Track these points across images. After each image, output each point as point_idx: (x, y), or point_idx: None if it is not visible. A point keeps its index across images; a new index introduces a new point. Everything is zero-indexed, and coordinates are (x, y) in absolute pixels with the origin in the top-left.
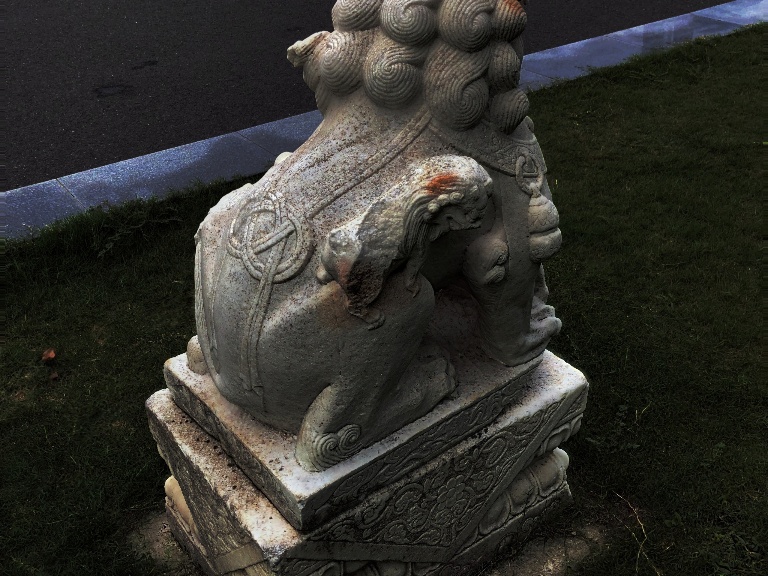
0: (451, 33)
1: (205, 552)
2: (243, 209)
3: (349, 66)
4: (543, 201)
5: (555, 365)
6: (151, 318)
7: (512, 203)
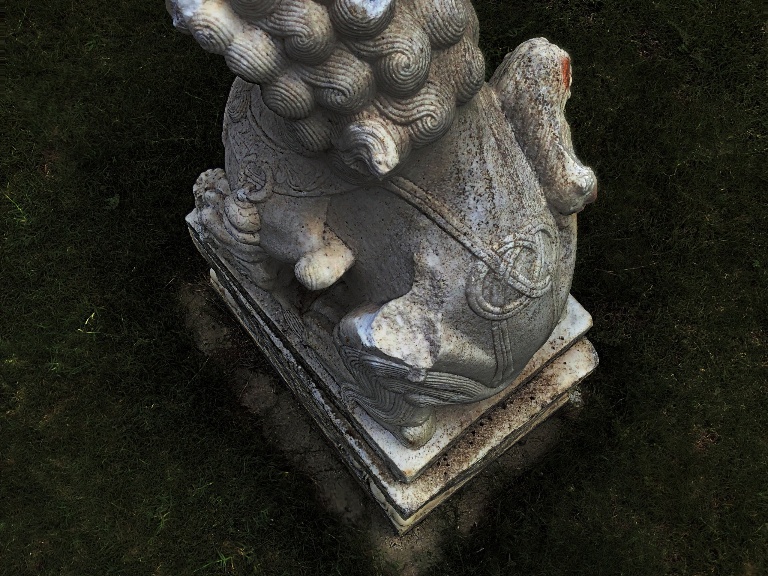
0: None
1: (473, 475)
2: (484, 291)
3: None
4: None
5: None
6: None
7: None
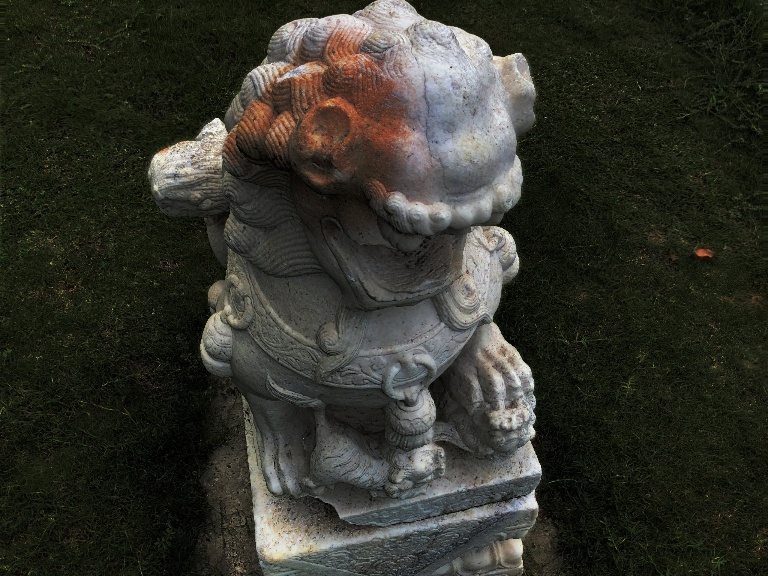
0: None
1: None
2: None
3: None
4: (216, 323)
5: (298, 537)
6: (766, 346)
7: None
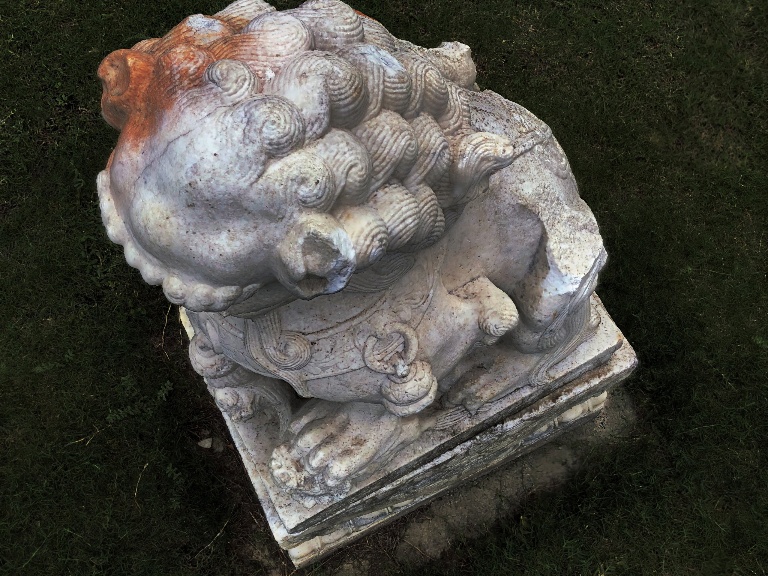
0: None
1: None
2: None
3: None
4: None
5: None
6: None
7: None
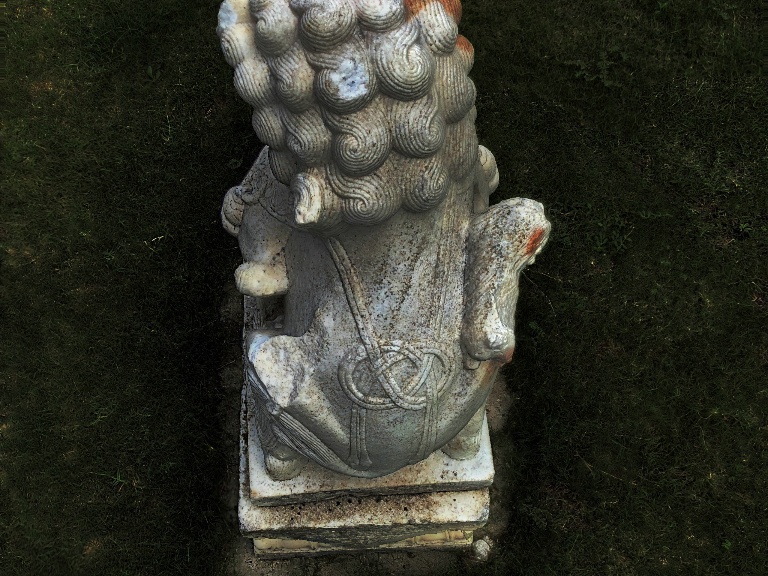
0: (457, 116)
1: (342, 548)
2: (355, 372)
3: (392, 205)
4: (485, 153)
5: None
6: None
7: (480, 177)
